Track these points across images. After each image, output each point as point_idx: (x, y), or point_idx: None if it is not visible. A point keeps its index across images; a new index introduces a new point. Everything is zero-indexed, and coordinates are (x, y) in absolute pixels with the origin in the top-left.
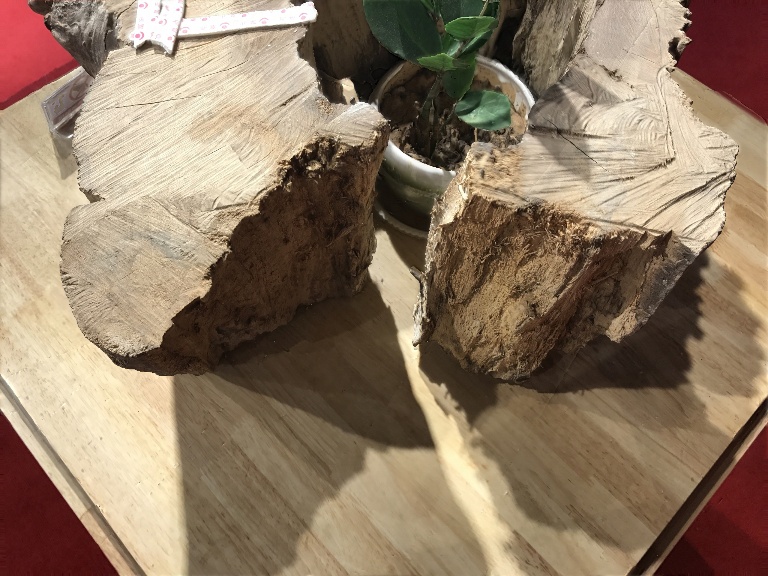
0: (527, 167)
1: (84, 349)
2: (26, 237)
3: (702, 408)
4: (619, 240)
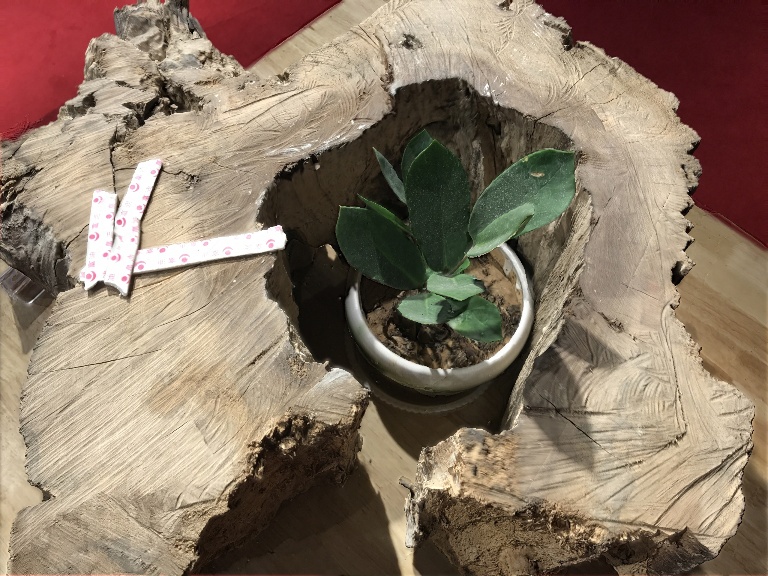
0: (524, 458)
1: None
2: None
3: None
4: (629, 538)
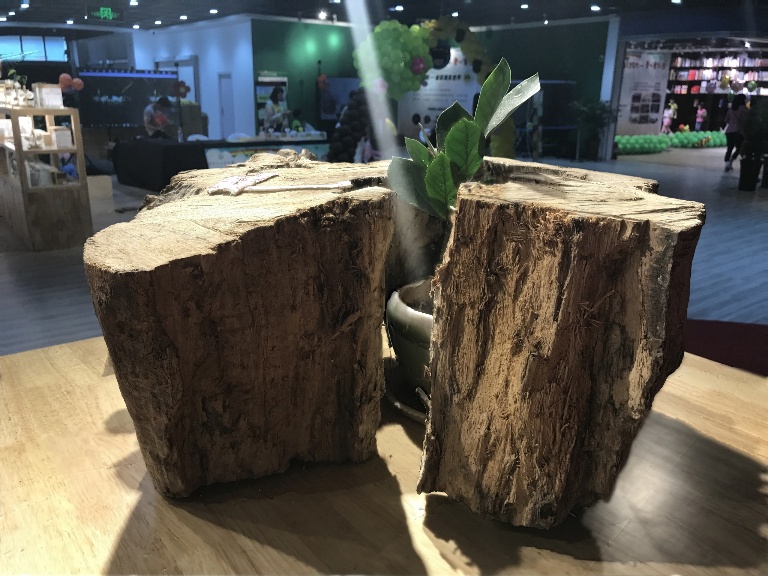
0: (509, 191)
1: (51, 479)
2: (46, 405)
3: None
4: (599, 227)
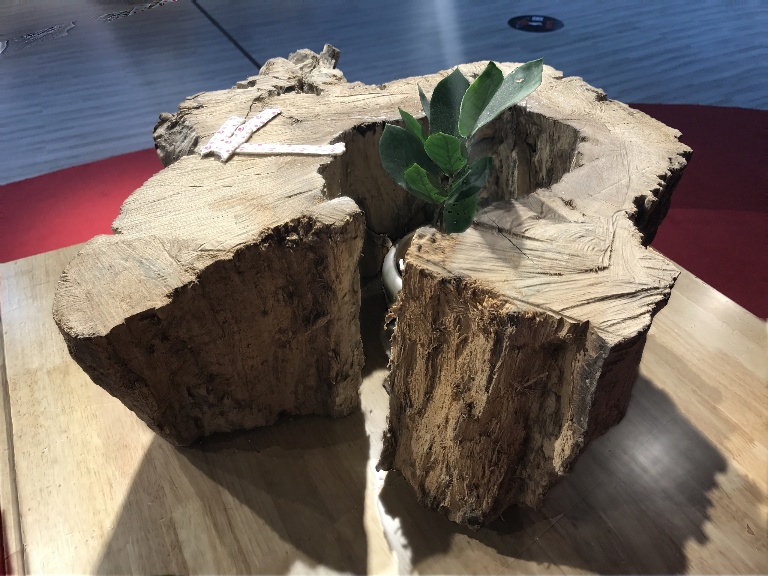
0: (462, 250)
1: (87, 409)
2: None
3: None
4: (535, 322)
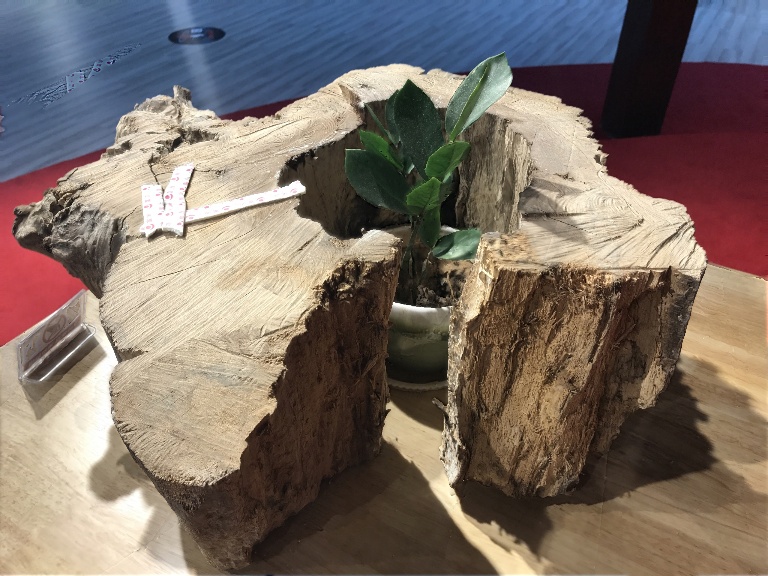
0: (534, 242)
1: None
2: (2, 485)
3: (742, 480)
4: (632, 283)
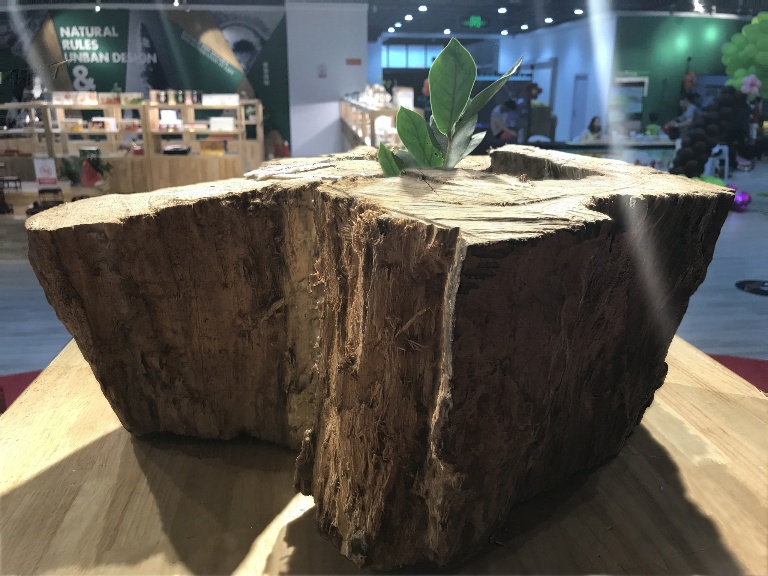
0: (373, 185)
1: (86, 397)
2: None
3: None
4: None
